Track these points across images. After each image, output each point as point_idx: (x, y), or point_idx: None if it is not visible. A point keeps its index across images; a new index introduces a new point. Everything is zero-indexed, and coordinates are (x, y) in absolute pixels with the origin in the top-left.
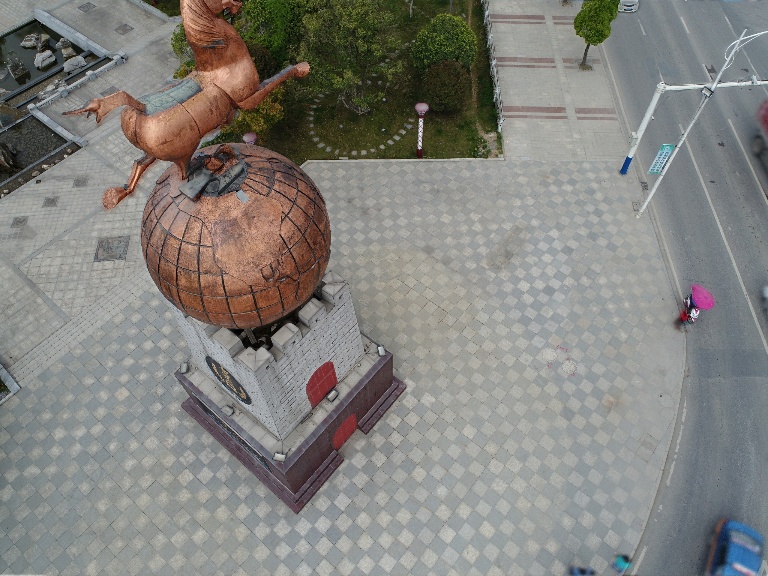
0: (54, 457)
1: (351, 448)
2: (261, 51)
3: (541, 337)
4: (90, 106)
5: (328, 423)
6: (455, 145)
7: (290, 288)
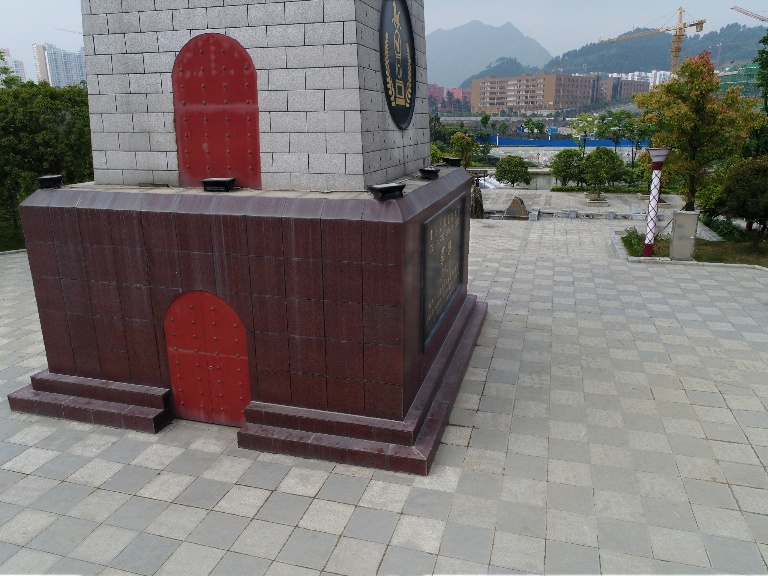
0: None
1: (193, 435)
2: None
3: None
4: None
5: (152, 207)
6: None
7: None
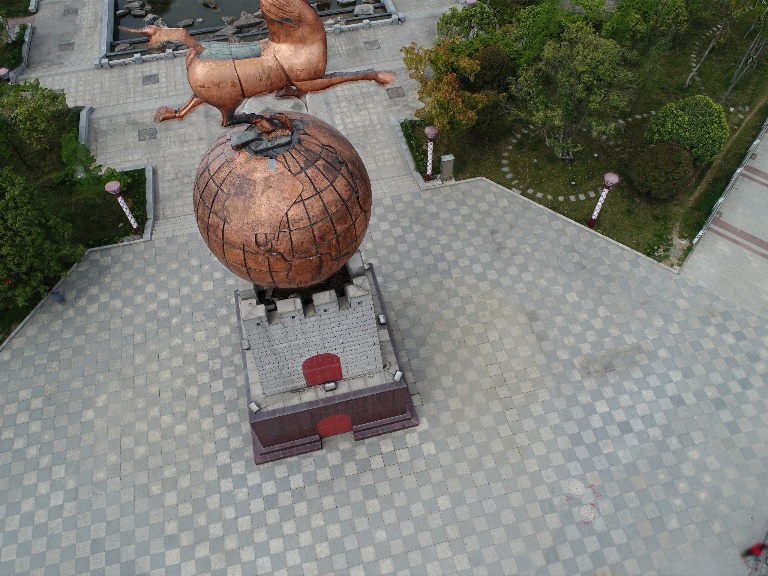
0: (136, 303)
1: (335, 443)
2: (502, 59)
3: (581, 466)
4: (146, 30)
5: (312, 407)
6: (637, 233)
7: (281, 265)
